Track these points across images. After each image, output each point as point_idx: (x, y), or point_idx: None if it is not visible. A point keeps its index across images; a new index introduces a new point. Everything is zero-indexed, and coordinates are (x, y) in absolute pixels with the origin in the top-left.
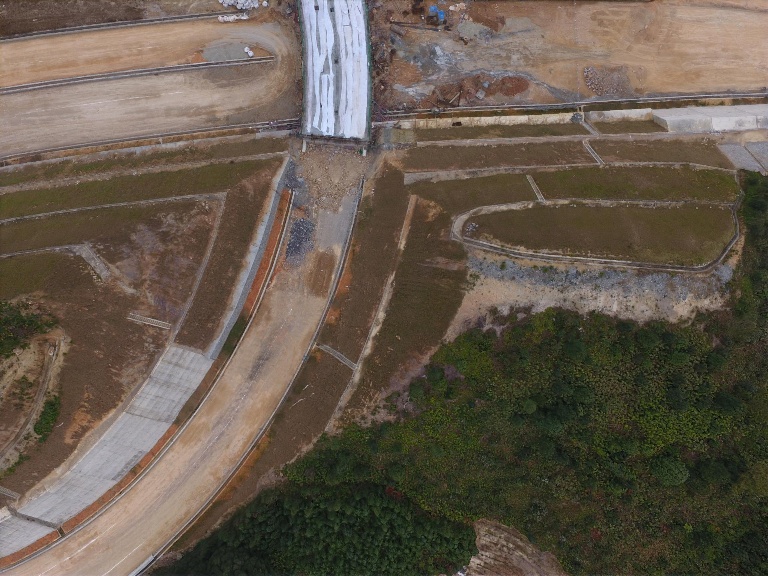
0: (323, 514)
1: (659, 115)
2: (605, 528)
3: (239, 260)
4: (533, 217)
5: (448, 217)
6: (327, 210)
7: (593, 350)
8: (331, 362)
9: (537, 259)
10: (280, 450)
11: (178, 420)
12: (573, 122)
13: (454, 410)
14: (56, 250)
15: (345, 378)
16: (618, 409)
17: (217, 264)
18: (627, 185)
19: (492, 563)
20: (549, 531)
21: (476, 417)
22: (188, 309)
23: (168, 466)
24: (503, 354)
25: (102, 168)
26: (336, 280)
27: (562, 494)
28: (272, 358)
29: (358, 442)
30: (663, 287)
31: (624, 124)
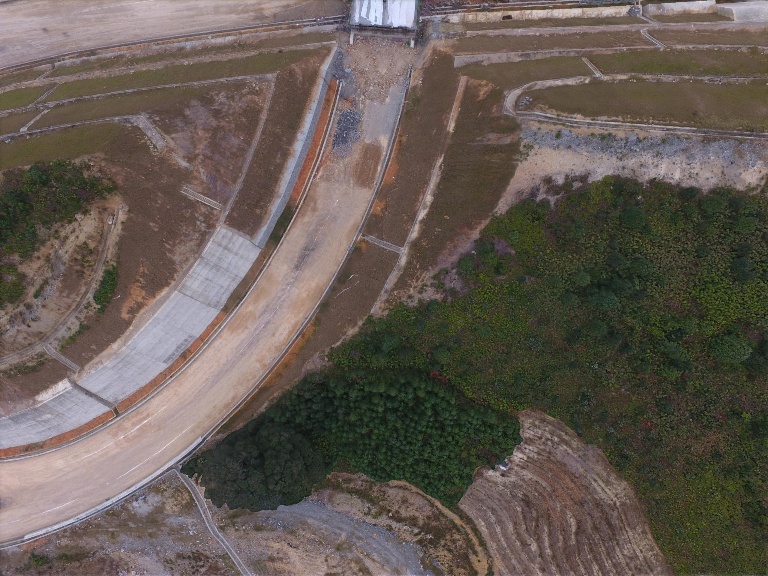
0: (367, 398)
1: (724, 6)
2: (656, 418)
3: (287, 147)
4: (590, 91)
5: (501, 92)
6: (374, 101)
7: (652, 219)
8: (376, 251)
9: (595, 127)
10: (325, 336)
11: (226, 307)
12: (630, 15)
13: (503, 287)
14: (115, 120)
15: (391, 262)
16: (677, 283)
17: (266, 147)
18: (691, 63)
19: (535, 457)
20: (596, 422)
21: (525, 295)
22: (238, 190)
23: (216, 352)
24: (557, 224)
25: (155, 60)
26: (382, 171)
27: (612, 381)
28: (318, 249)
29: (404, 323)
30: (730, 154)
31: (685, 16)
